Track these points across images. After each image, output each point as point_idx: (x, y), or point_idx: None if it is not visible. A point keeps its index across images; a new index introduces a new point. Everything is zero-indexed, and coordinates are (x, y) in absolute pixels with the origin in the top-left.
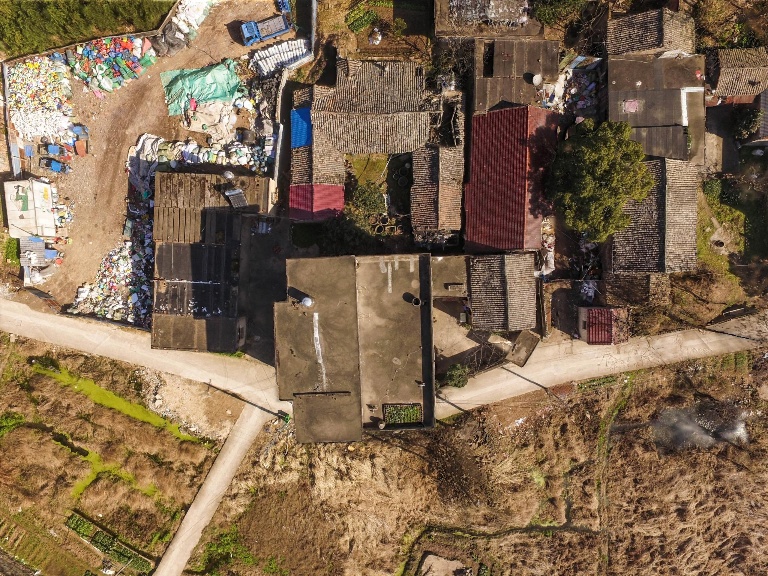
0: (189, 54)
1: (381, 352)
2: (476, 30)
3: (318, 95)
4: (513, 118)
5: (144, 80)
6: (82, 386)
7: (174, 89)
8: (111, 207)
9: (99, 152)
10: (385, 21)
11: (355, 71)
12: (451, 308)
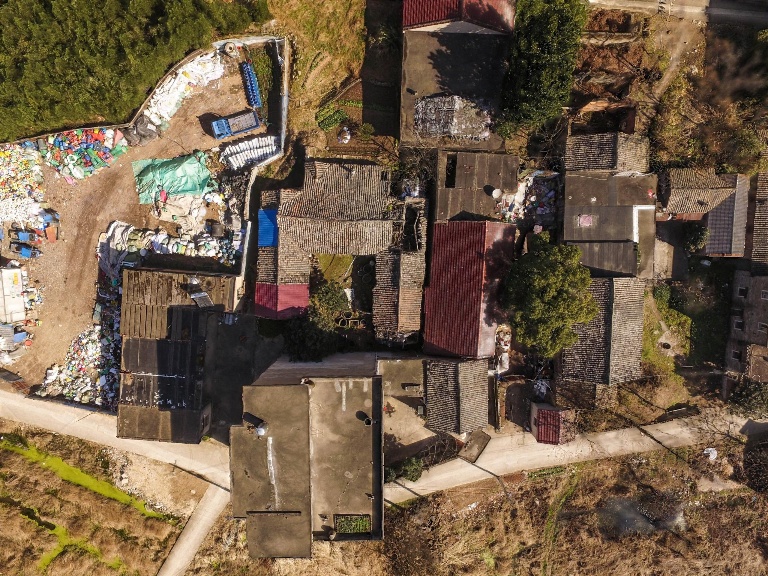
0: (161, 144)
1: (334, 466)
2: (440, 142)
3: (285, 199)
4: (472, 231)
5: (116, 168)
6: (50, 463)
7: (145, 180)
8: (81, 291)
9: (70, 237)
10: (354, 120)
11: (323, 173)
12: (410, 400)
